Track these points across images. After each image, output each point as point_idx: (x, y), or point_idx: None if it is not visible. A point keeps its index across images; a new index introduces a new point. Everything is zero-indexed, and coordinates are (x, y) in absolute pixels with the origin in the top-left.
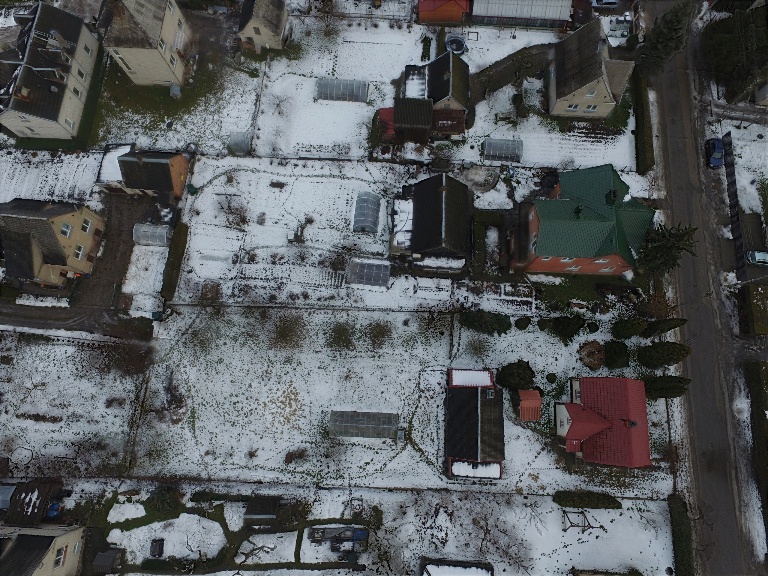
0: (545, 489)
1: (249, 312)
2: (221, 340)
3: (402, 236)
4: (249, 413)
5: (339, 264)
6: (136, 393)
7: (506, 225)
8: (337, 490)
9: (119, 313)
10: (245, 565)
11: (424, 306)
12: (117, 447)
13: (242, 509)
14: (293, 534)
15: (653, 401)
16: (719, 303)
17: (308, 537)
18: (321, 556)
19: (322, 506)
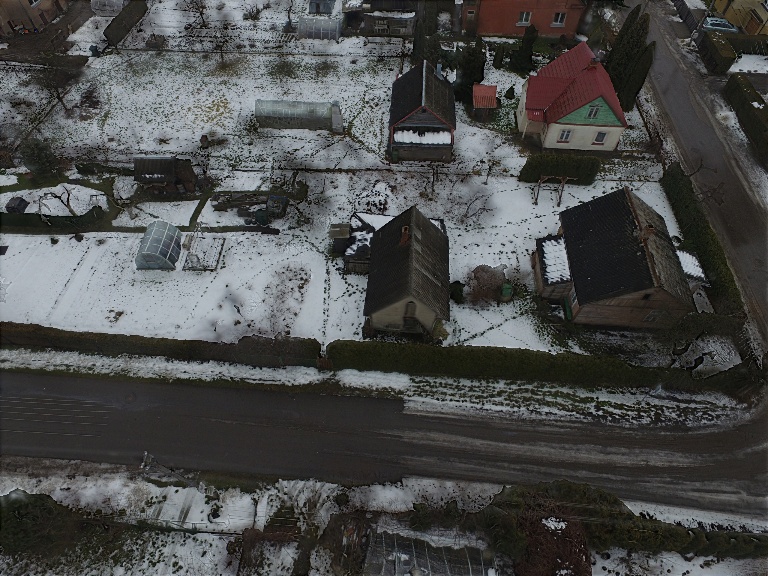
0: (508, 171)
1: (192, 55)
2: (156, 70)
3: (354, 1)
4: (170, 115)
5: (290, 27)
6: (49, 100)
7: (458, 11)
8: (257, 172)
9: (57, 52)
10: (124, 227)
11: (374, 52)
12: (9, 134)
13: (137, 182)
14: (193, 202)
15: (625, 112)
16: (680, 55)
17: (211, 199)
18: (224, 220)
19: (235, 181)
